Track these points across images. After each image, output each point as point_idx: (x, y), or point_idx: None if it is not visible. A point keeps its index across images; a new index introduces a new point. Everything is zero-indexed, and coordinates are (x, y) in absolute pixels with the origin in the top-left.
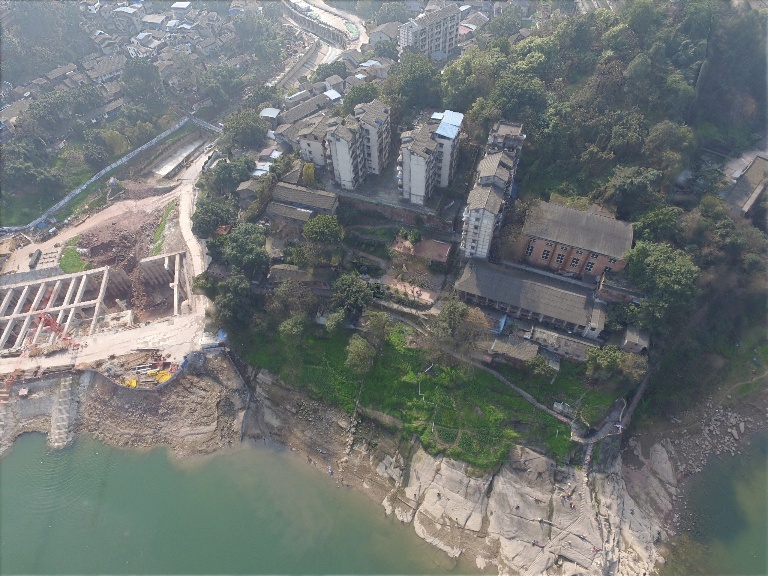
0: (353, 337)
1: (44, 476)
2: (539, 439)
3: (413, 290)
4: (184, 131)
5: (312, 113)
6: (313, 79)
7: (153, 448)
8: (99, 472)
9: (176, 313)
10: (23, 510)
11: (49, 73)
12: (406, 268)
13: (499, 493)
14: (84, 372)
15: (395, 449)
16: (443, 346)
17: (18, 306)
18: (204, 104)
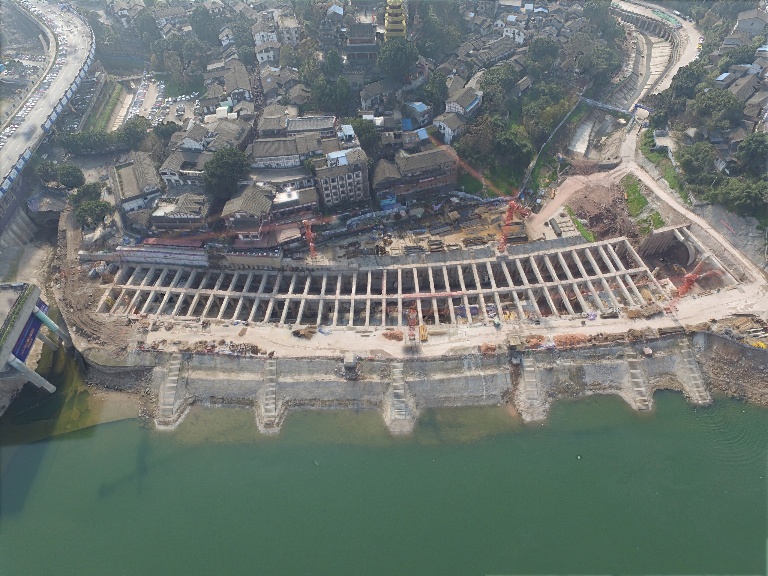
0: None
1: (712, 431)
2: None
3: None
4: (581, 111)
5: (751, 94)
6: (726, 62)
7: None
8: (762, 429)
9: (737, 282)
10: (715, 462)
11: (458, 51)
12: None
13: None
14: (696, 334)
15: None
16: None
17: (569, 271)
18: (589, 86)
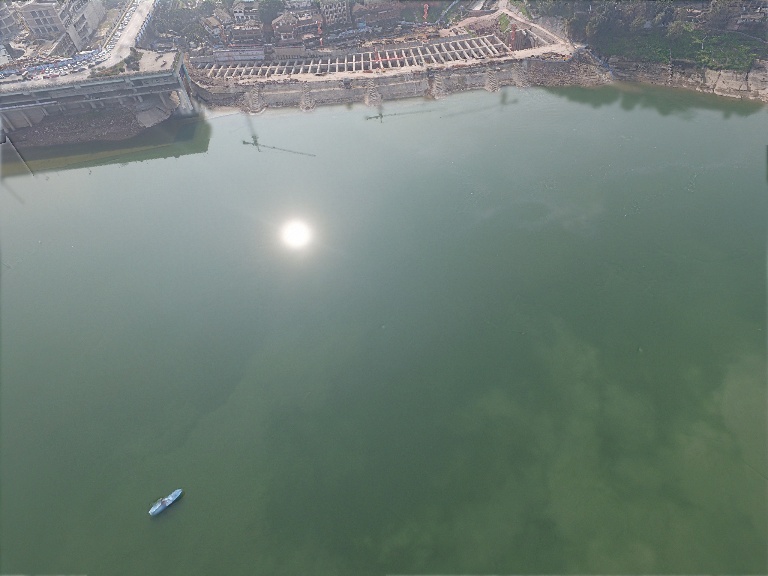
0: (670, 23)
1: None
2: (767, 55)
3: (689, 9)
4: None
5: None
6: None
7: (572, 85)
8: None
9: None
10: (526, 103)
11: None
12: (680, 3)
13: (752, 77)
14: (523, 61)
15: (695, 72)
16: (721, 16)
17: None
18: None
